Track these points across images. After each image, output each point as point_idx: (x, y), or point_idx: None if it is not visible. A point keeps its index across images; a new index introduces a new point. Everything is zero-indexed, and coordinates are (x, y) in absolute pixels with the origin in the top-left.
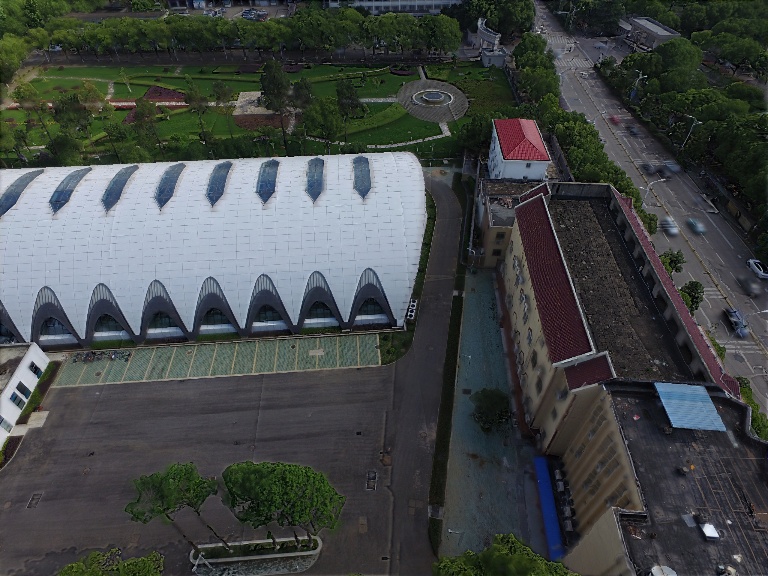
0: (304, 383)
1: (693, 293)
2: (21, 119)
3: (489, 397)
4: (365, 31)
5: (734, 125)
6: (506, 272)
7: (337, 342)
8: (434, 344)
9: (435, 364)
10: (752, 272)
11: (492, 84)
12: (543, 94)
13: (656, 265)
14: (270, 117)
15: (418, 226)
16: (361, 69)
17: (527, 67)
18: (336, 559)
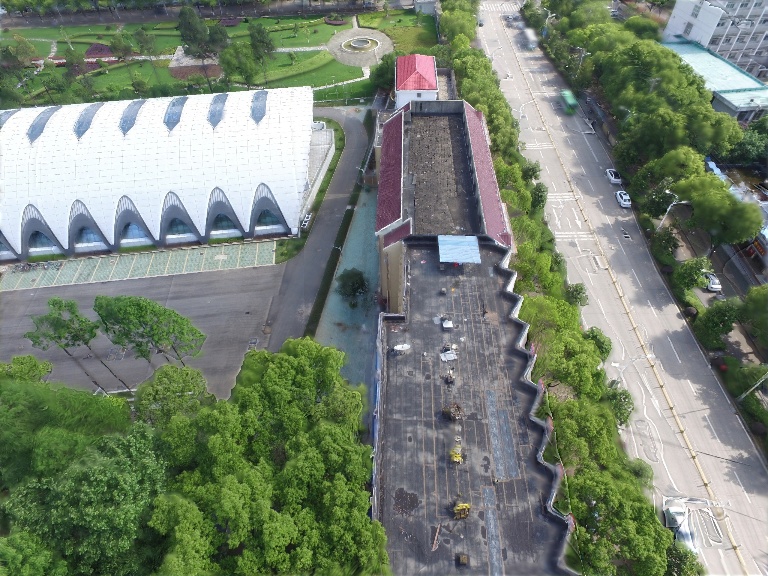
0: (207, 280)
1: (537, 192)
2: None
3: (346, 274)
4: None
5: (614, 53)
6: None
7: (239, 249)
8: (322, 247)
9: (320, 261)
10: (607, 179)
11: (419, 30)
12: None
13: (481, 160)
14: None
15: (305, 146)
16: (297, 21)
17: (446, 11)
18: (216, 396)
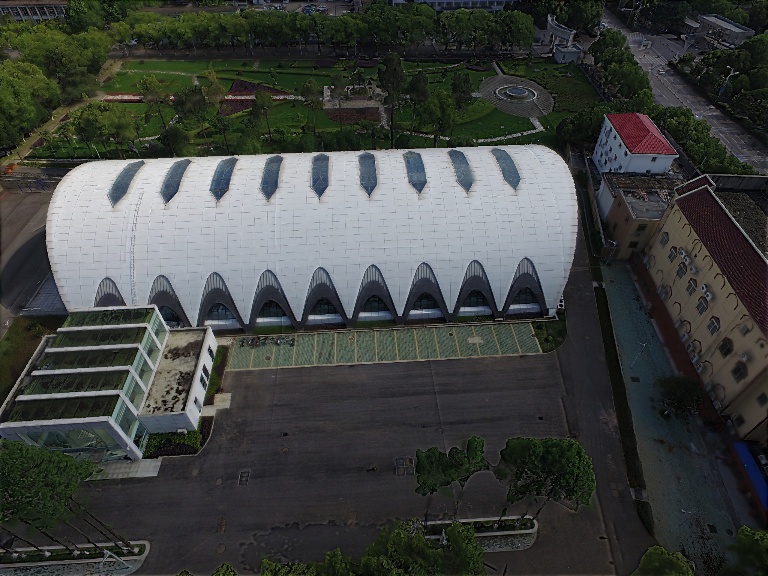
0: (472, 369)
1: None
2: None
3: (681, 383)
4: (441, 27)
5: None
6: (654, 263)
7: (492, 330)
8: (589, 333)
9: (596, 353)
10: None
11: (572, 80)
12: (635, 90)
13: None
14: (361, 111)
15: (572, 217)
16: (436, 64)
17: (614, 63)
18: (555, 538)
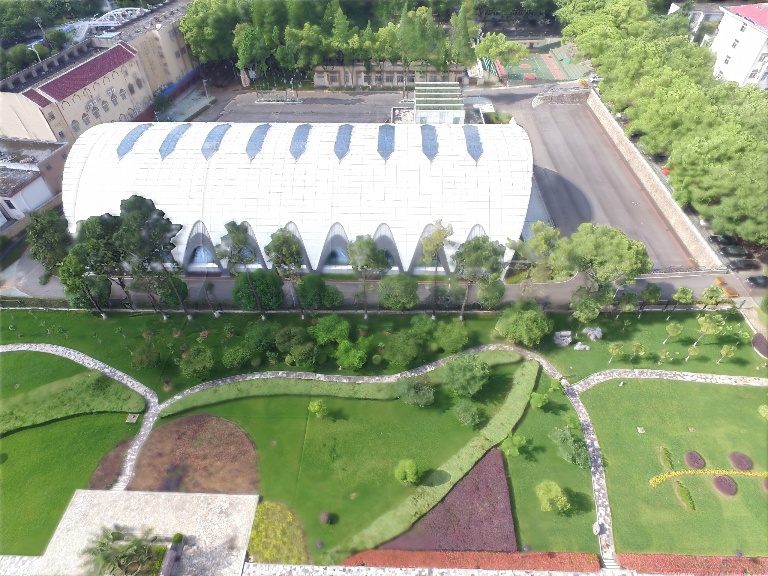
0: None
1: None
2: (759, 498)
3: (162, 97)
4: None
5: None
6: None
7: None
8: None
9: None
10: None
11: None
12: None
13: None
14: (174, 474)
15: None
16: None
17: None
18: None
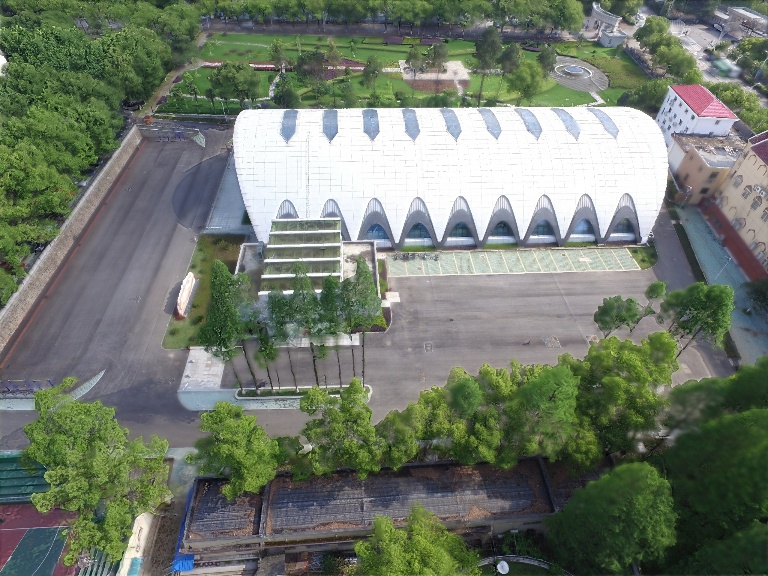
0: (587, 279)
1: None
2: None
3: (766, 282)
4: (500, 10)
5: None
6: (726, 203)
7: (597, 253)
8: (676, 257)
9: (684, 270)
10: None
11: (620, 61)
12: (684, 69)
13: None
14: (438, 82)
15: (664, 161)
16: None
17: (663, 46)
18: None
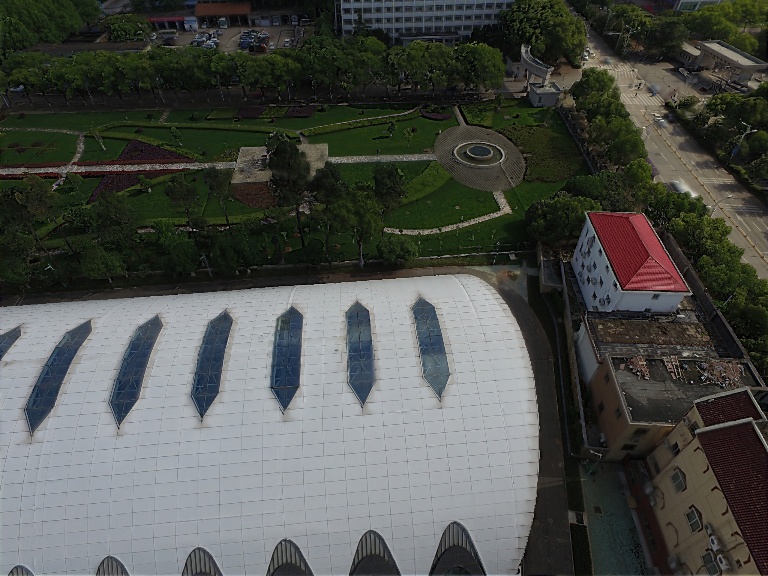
0: None
1: None
2: None
3: None
4: (390, 66)
5: None
6: (662, 505)
7: None
8: None
9: None
10: None
11: (548, 132)
12: (626, 155)
13: None
14: None
15: (530, 447)
16: (385, 111)
17: (599, 116)
18: None
